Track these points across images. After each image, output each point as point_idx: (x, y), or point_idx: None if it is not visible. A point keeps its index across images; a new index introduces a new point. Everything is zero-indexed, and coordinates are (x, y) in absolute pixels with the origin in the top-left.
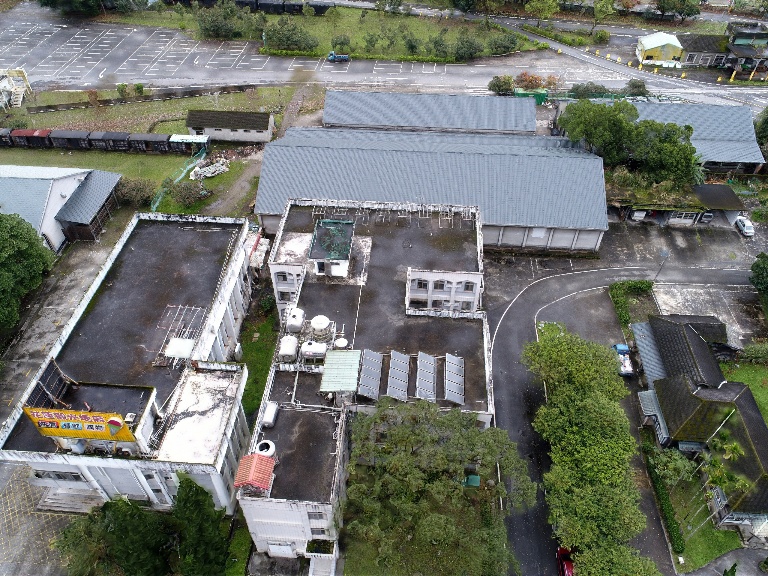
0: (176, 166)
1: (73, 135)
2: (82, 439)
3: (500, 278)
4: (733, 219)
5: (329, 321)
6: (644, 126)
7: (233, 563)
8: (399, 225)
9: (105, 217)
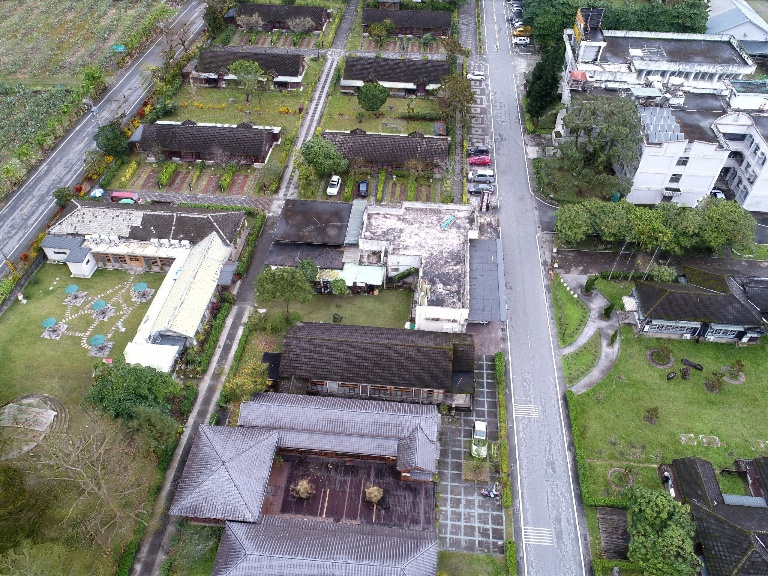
0: None
1: None
2: None
3: None
4: None
5: None
6: None
7: (546, 130)
8: None
9: None
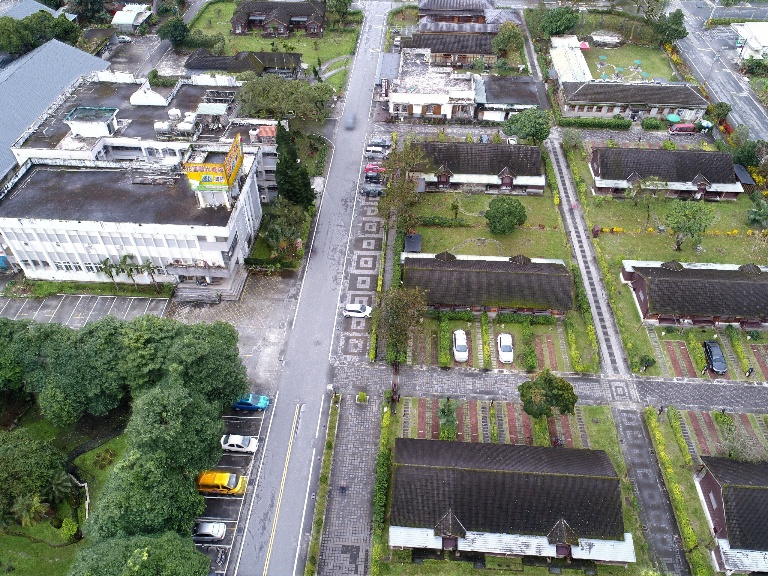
0: None
1: None
2: (235, 179)
3: None
4: (116, 39)
5: None
6: (32, 19)
7: None
8: None
9: None
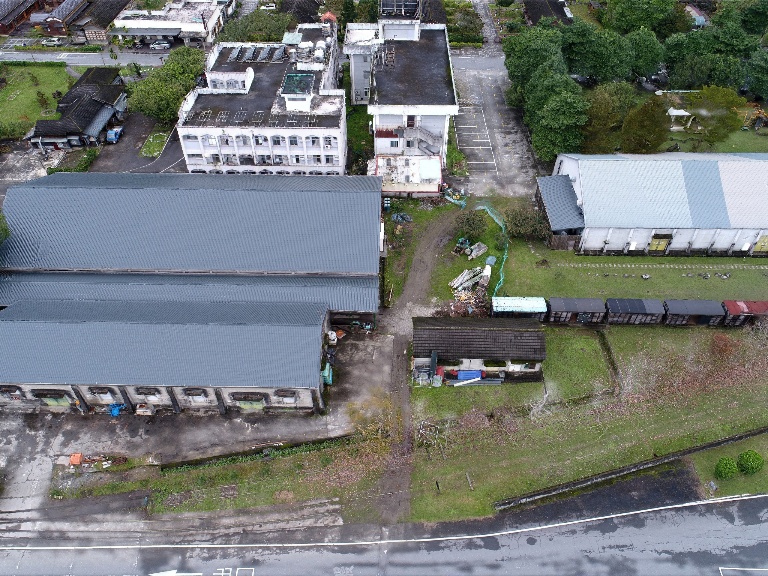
0: (522, 292)
1: (686, 302)
2: None
3: None
4: None
5: None
6: None
7: None
8: (247, 120)
9: None
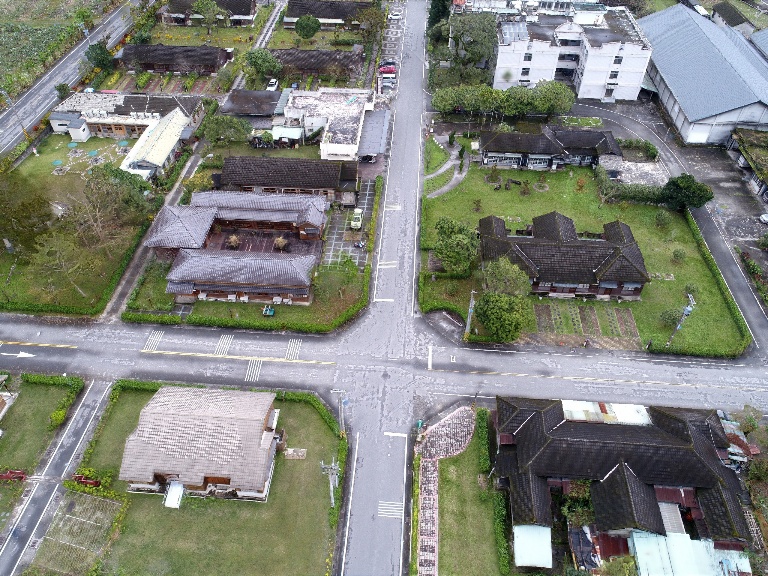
0: None
1: None
2: None
3: (635, 110)
4: None
5: (532, 6)
6: None
7: None
8: None
9: (615, 5)
